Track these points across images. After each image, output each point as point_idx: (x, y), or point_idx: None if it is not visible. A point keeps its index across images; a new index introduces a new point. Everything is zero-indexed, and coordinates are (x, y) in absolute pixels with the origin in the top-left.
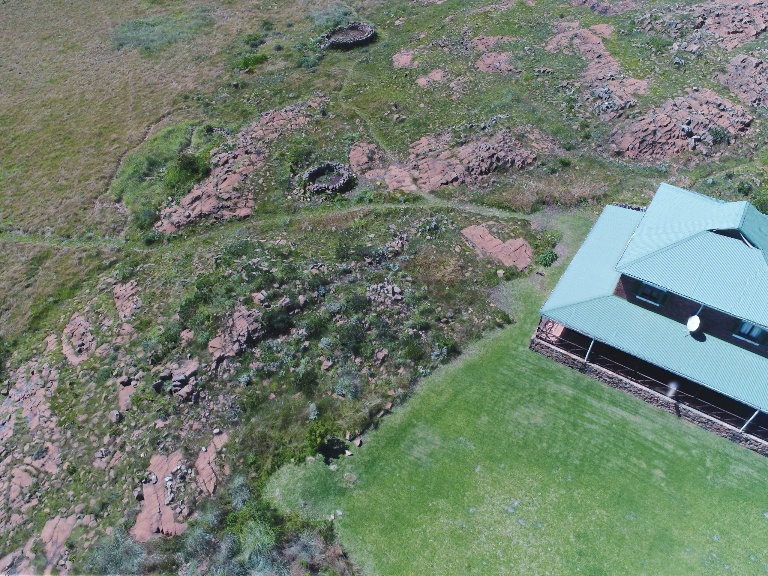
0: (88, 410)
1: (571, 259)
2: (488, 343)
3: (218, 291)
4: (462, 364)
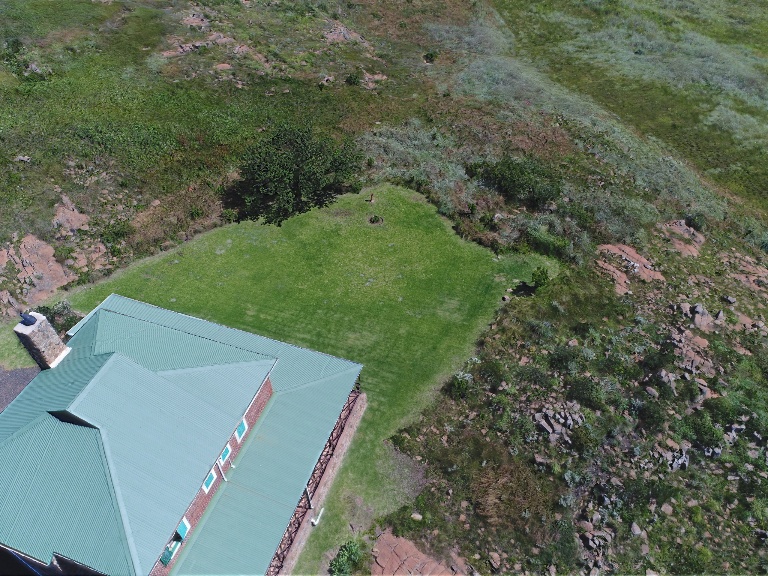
0: (764, 311)
1: (306, 574)
2: (414, 407)
3: (764, 394)
4: (437, 378)
